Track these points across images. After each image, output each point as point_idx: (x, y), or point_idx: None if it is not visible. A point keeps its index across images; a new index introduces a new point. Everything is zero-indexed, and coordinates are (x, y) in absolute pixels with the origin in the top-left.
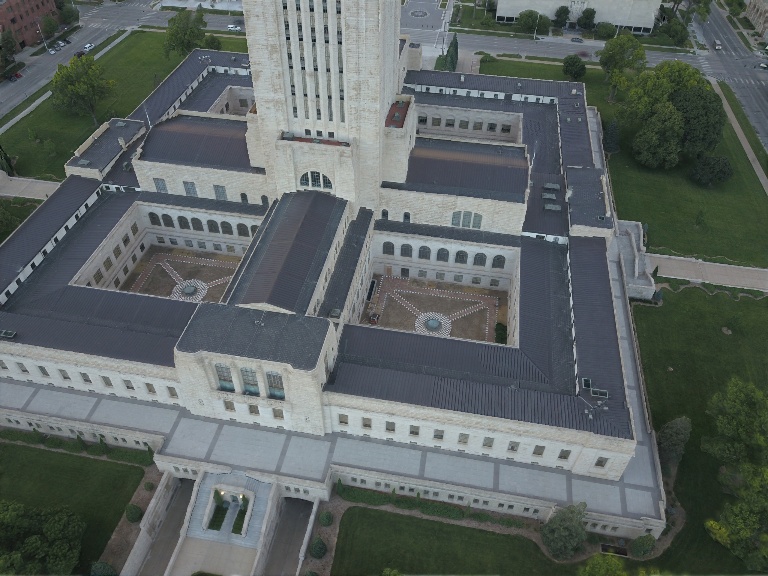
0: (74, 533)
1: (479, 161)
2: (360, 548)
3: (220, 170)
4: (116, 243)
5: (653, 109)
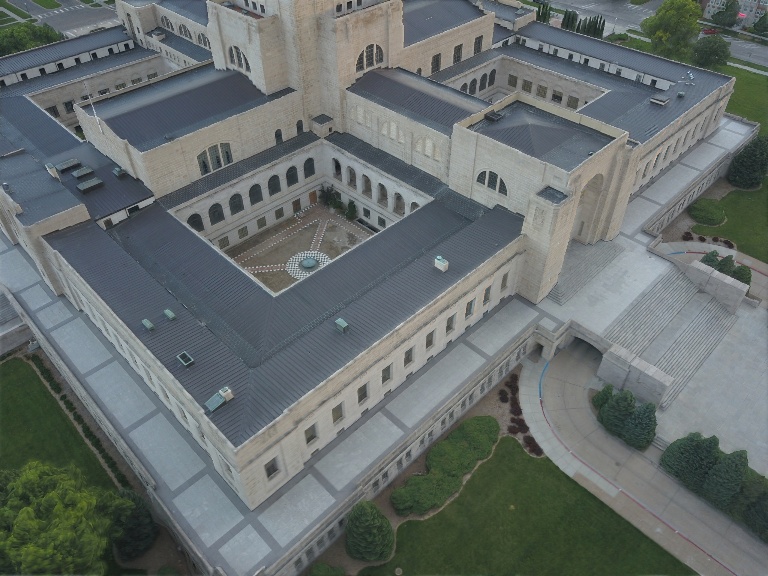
0: None
1: (166, 102)
2: None
3: None
4: None
5: None
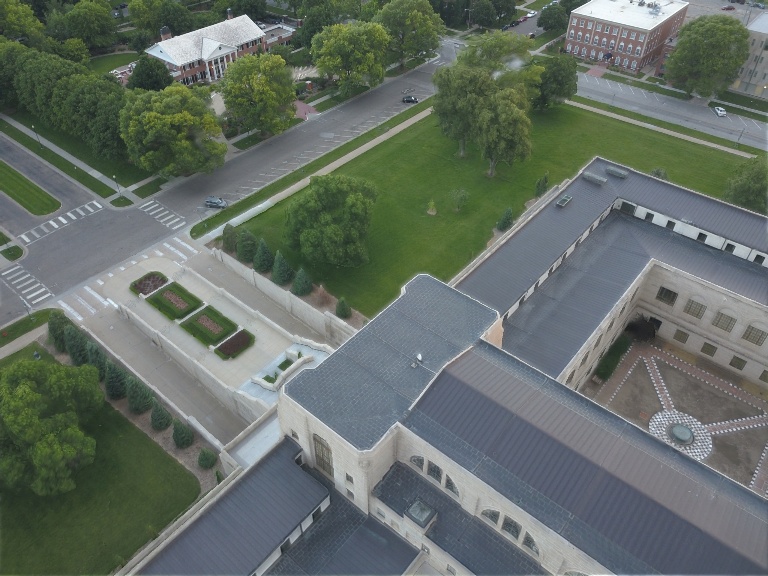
0: (326, 249)
1: None
2: (151, 481)
3: None
4: (767, 329)
5: None
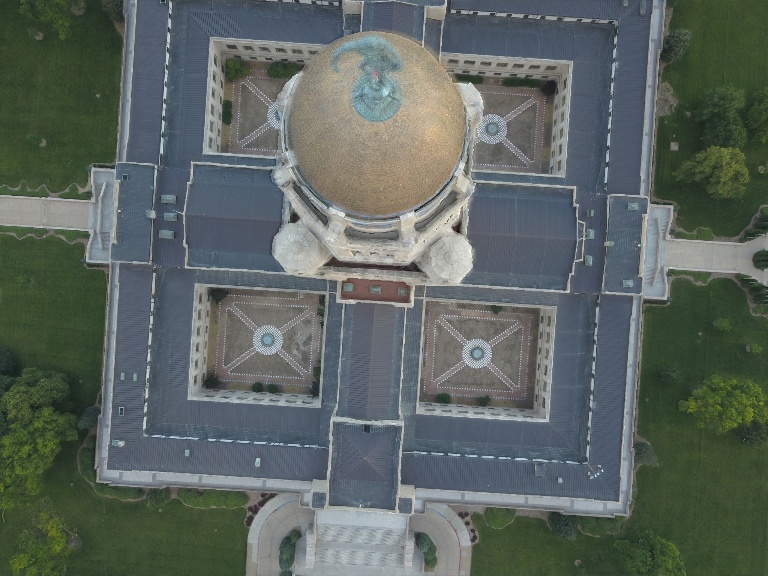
0: None
1: (234, 222)
2: None
3: (485, 181)
4: None
5: (33, 414)
